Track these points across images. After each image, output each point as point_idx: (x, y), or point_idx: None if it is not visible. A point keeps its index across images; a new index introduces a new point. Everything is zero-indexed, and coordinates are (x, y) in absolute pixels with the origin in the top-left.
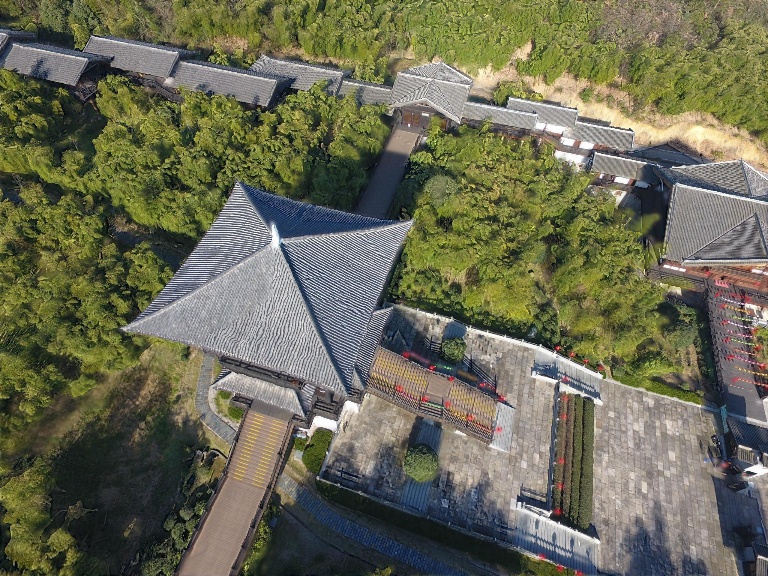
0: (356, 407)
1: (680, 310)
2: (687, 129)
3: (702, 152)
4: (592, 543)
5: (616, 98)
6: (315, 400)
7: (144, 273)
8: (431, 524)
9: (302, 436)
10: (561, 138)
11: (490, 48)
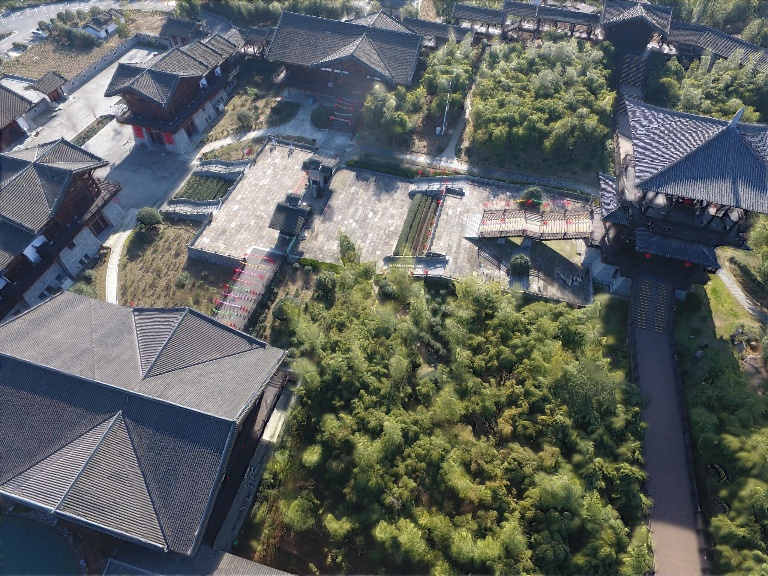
0: None
1: None
2: None
3: None
4: None
5: None
6: None
7: None
8: None
9: None
10: None
11: None
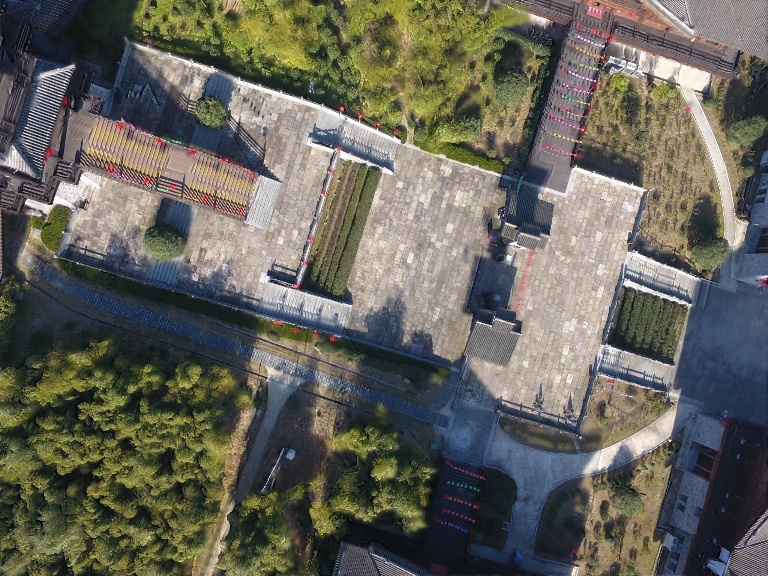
0: (93, 183)
1: (533, 50)
2: None
3: None
4: (344, 306)
5: None
6: (21, 181)
7: None
8: (178, 296)
9: (36, 215)
10: None
11: None
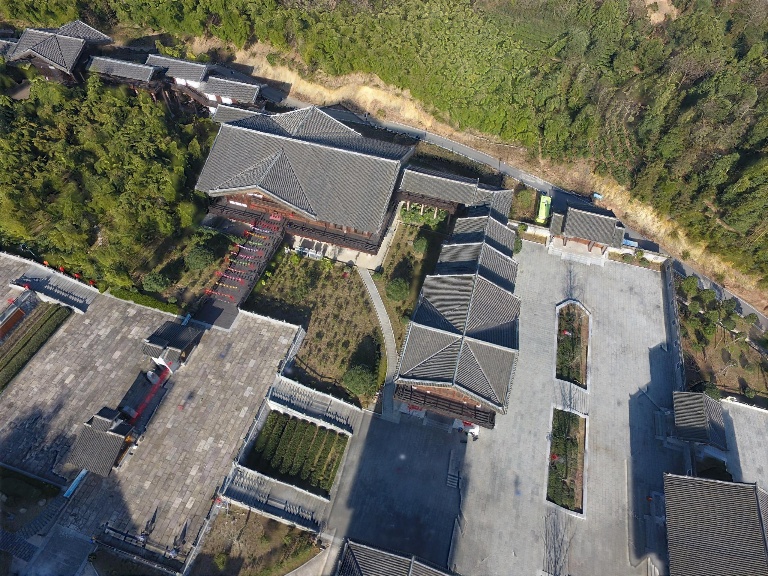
0: None
1: (234, 241)
2: (357, 90)
3: (370, 111)
4: None
5: (298, 61)
6: None
7: None
8: None
9: None
10: (204, 93)
11: (185, 15)
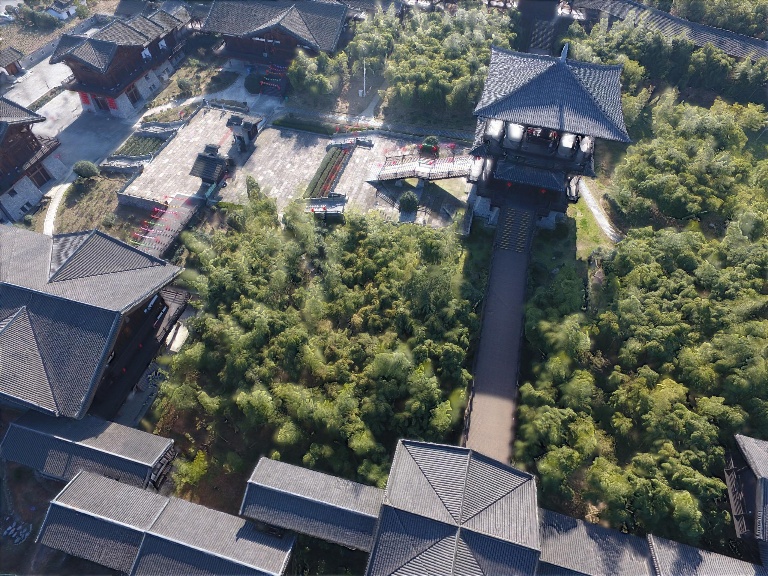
0: None
1: None
2: None
3: None
4: None
5: None
6: None
7: (668, 179)
8: None
9: None
10: None
11: None
